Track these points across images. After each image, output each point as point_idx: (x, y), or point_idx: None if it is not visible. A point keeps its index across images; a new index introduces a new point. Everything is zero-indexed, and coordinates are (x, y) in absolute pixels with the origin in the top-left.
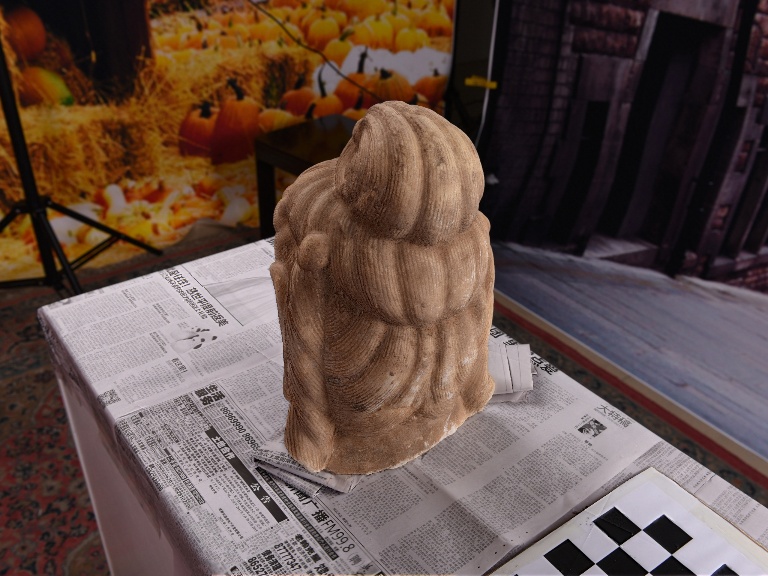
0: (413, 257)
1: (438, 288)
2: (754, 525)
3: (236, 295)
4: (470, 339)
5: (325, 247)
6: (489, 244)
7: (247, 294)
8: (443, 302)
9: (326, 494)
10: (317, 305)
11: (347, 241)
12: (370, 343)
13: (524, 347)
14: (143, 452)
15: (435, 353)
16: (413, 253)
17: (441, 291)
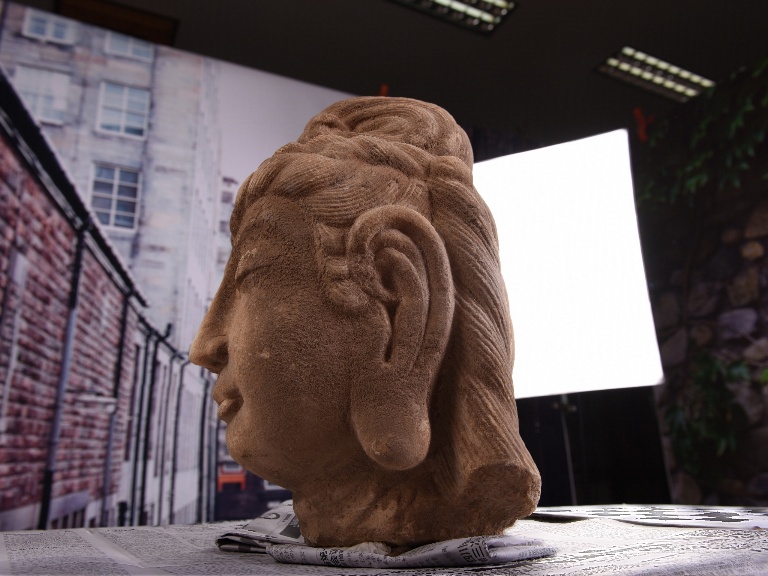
0: None
1: None
2: None
3: None
4: None
5: None
6: None
7: None
8: None
9: None
10: None
11: None
12: None
13: None
14: None
15: None
16: None
17: None
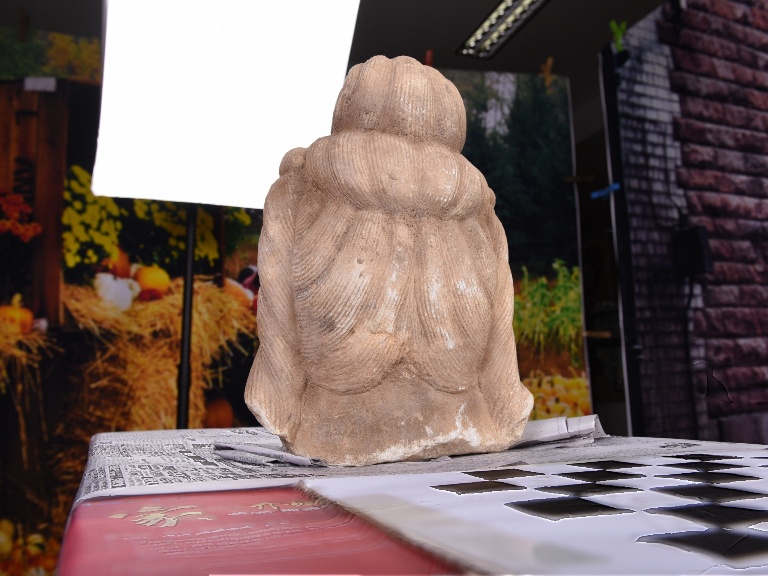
0: (383, 139)
1: (409, 164)
2: None
3: None
4: (463, 257)
5: (302, 149)
6: (487, 191)
7: None
8: (417, 184)
9: None
10: (288, 201)
11: None
12: (337, 227)
13: None
14: (100, 450)
15: (415, 253)
16: (383, 137)
17: (413, 170)
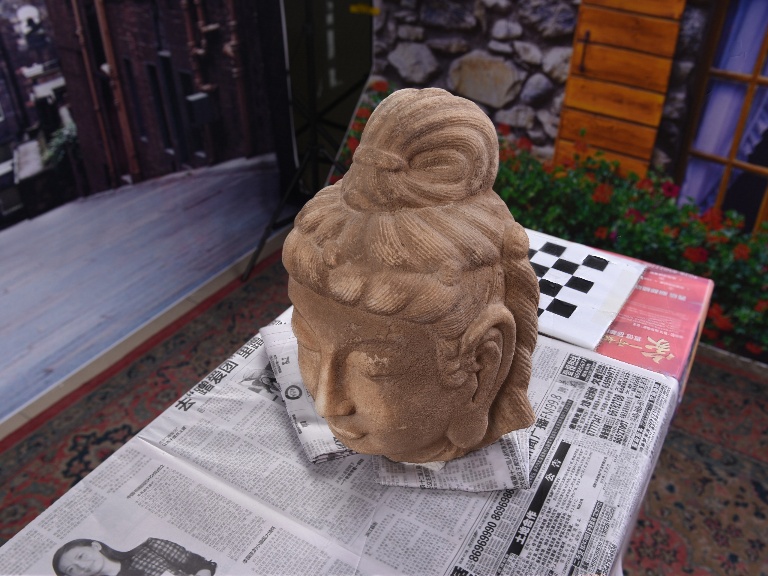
0: None
1: None
2: None
3: None
4: None
5: None
6: None
7: None
8: None
9: (517, 430)
10: None
11: None
12: None
13: (269, 330)
14: None
15: None
16: None
17: None
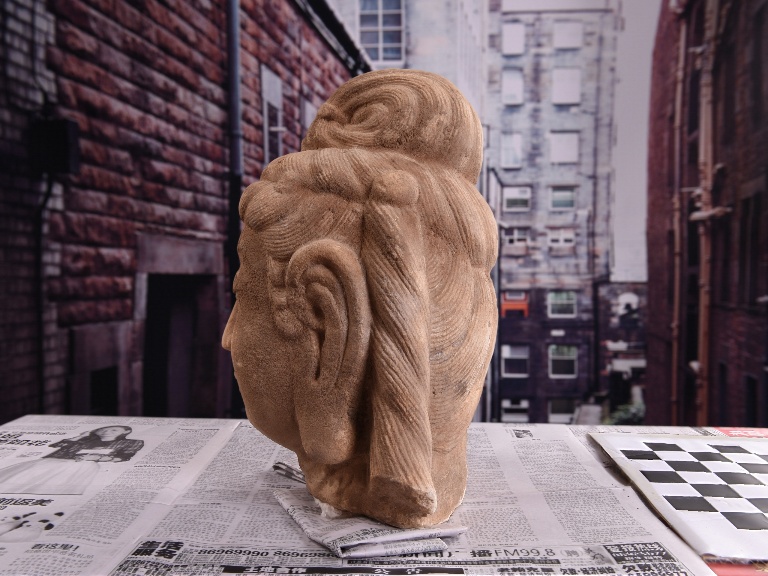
0: None
1: None
2: (674, 433)
3: (13, 482)
4: None
5: (413, 177)
6: None
7: (29, 477)
8: None
9: (448, 544)
10: (422, 246)
11: (427, 172)
12: None
13: None
14: None
15: None
16: None
17: None
